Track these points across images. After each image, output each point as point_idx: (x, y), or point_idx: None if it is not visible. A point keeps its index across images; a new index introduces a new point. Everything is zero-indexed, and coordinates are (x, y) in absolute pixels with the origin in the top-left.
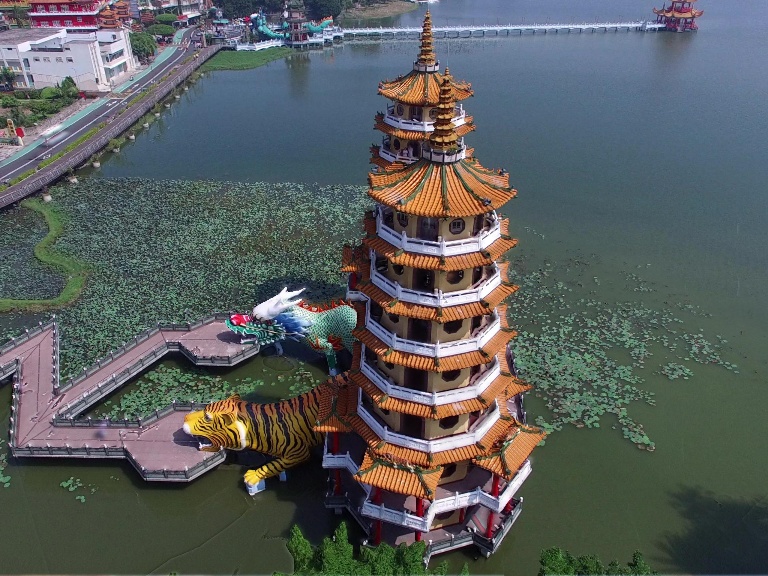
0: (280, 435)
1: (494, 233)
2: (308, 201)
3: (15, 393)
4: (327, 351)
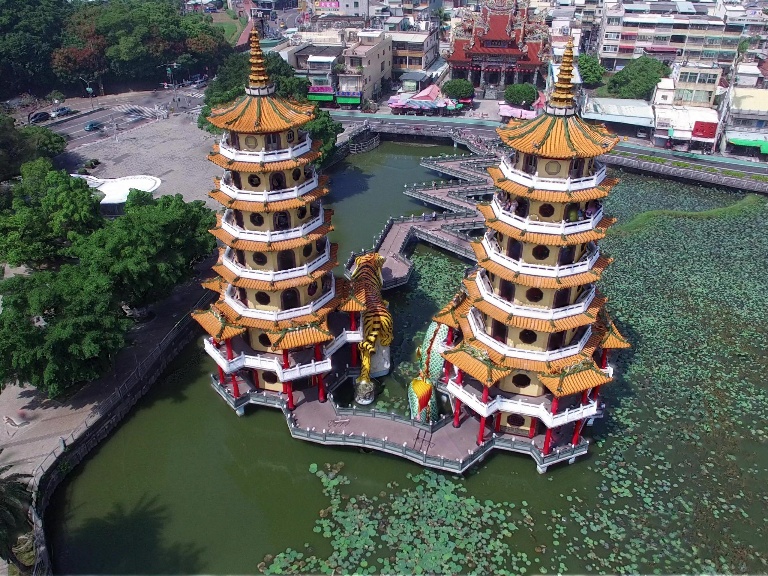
0: None
1: None
2: None
3: (435, 212)
4: None
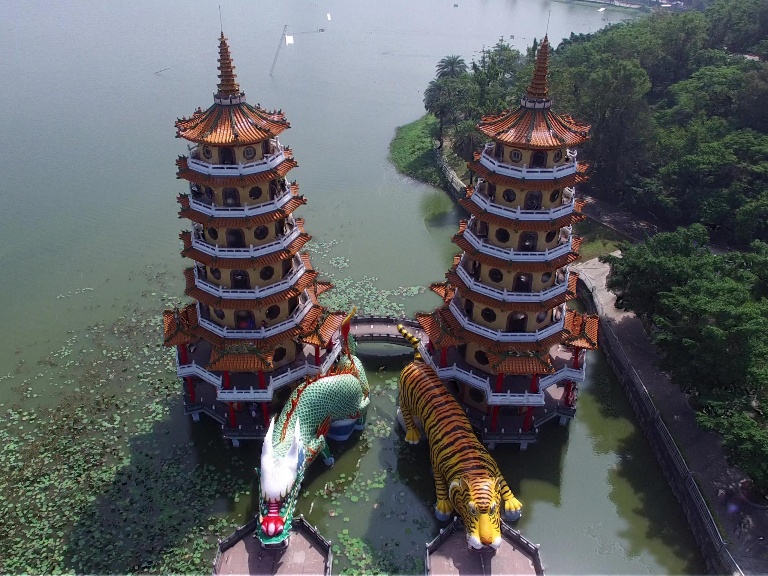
0: (489, 457)
1: None
2: None
3: None
4: (323, 446)
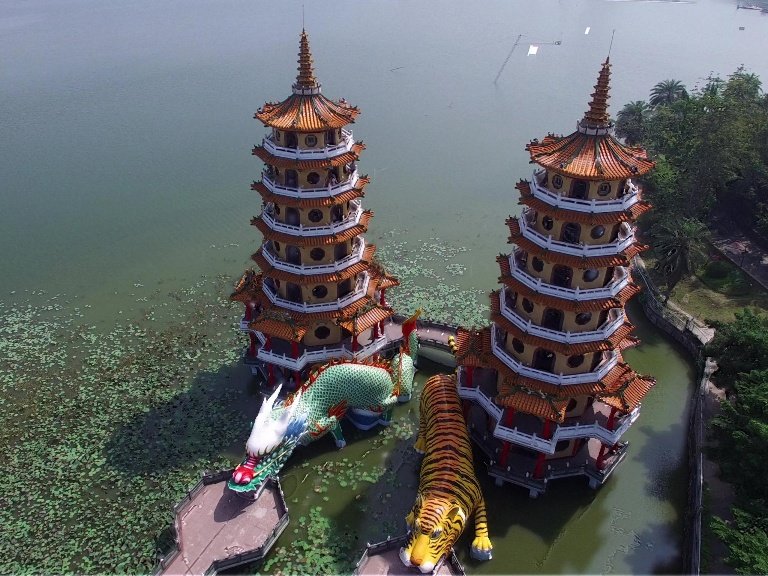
0: (472, 487)
1: None
2: None
3: None
4: (333, 426)
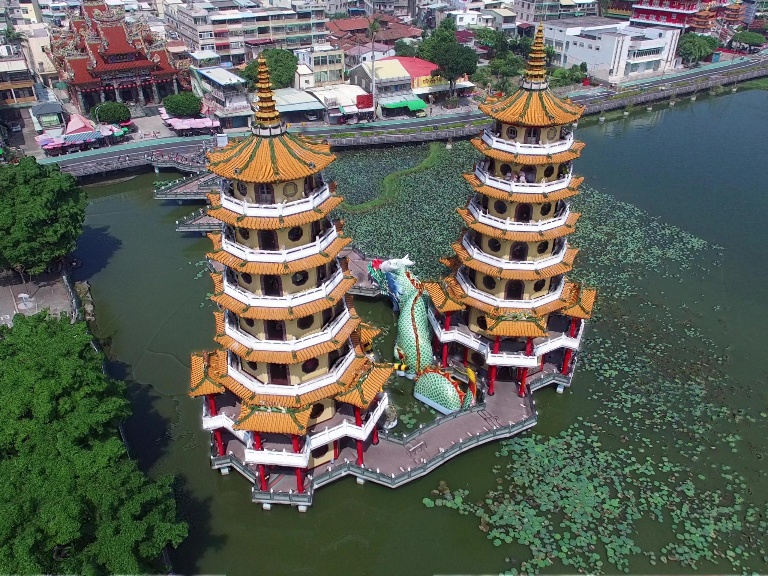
0: None
1: (272, 210)
2: (620, 227)
3: None
4: None
